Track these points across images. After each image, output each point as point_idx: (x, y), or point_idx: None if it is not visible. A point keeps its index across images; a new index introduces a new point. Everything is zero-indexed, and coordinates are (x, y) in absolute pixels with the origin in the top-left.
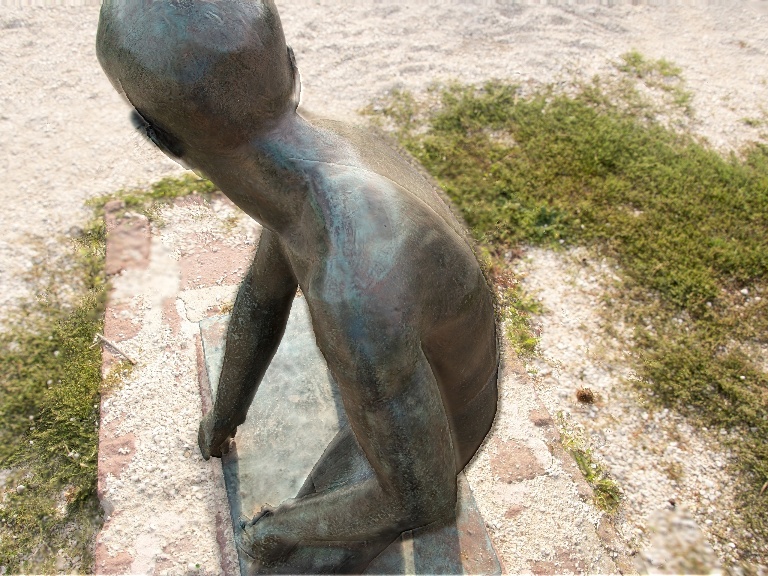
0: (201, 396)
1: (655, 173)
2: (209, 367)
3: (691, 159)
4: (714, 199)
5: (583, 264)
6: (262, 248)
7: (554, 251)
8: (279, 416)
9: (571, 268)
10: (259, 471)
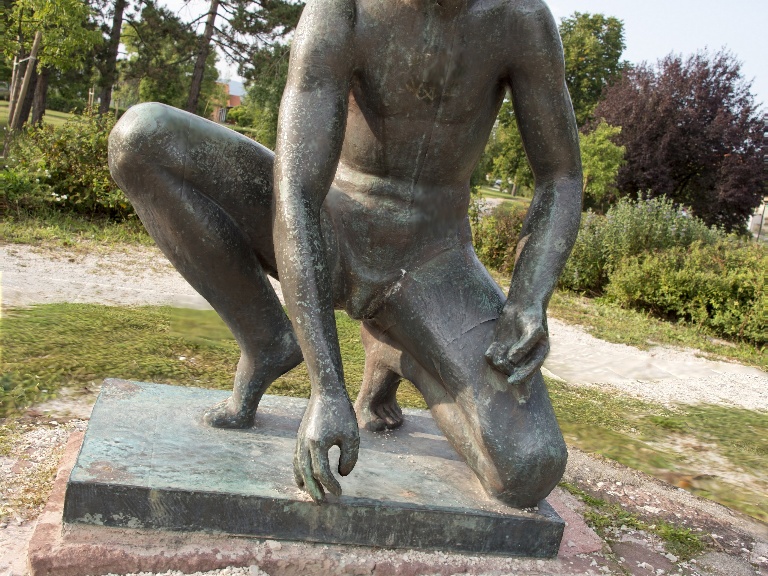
0: (159, 573)
1: (6, 334)
2: (171, 487)
3: (3, 323)
4: (68, 332)
5: (88, 393)
6: (320, 133)
7: (53, 399)
8: (279, 463)
9: (87, 399)
10: (354, 486)
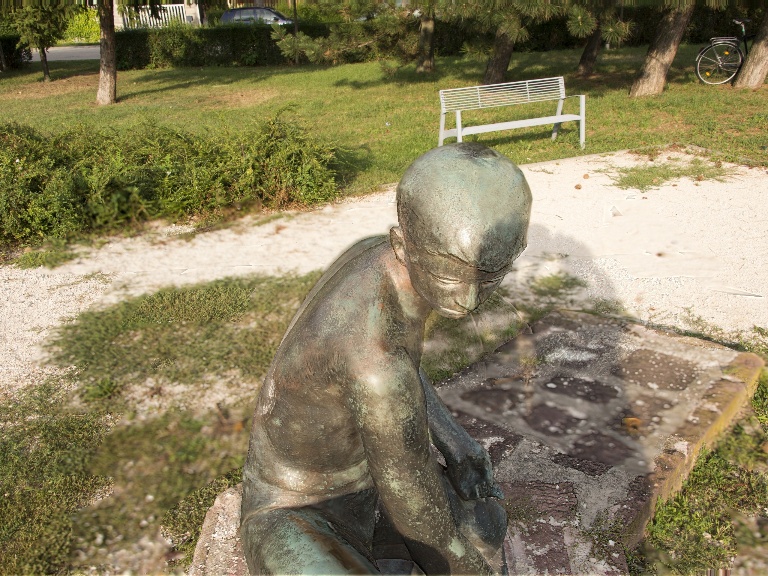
0: None
1: None
2: None
3: None
4: None
5: None
6: None
7: None
8: None
9: None
10: None
